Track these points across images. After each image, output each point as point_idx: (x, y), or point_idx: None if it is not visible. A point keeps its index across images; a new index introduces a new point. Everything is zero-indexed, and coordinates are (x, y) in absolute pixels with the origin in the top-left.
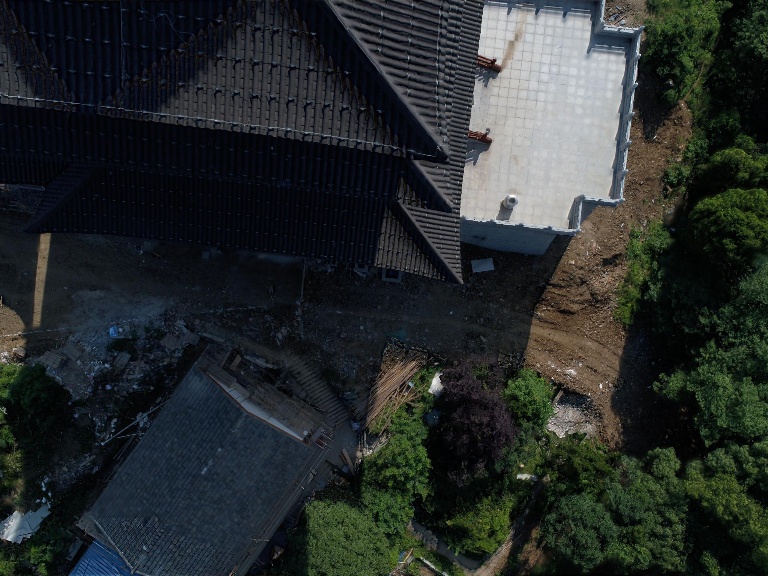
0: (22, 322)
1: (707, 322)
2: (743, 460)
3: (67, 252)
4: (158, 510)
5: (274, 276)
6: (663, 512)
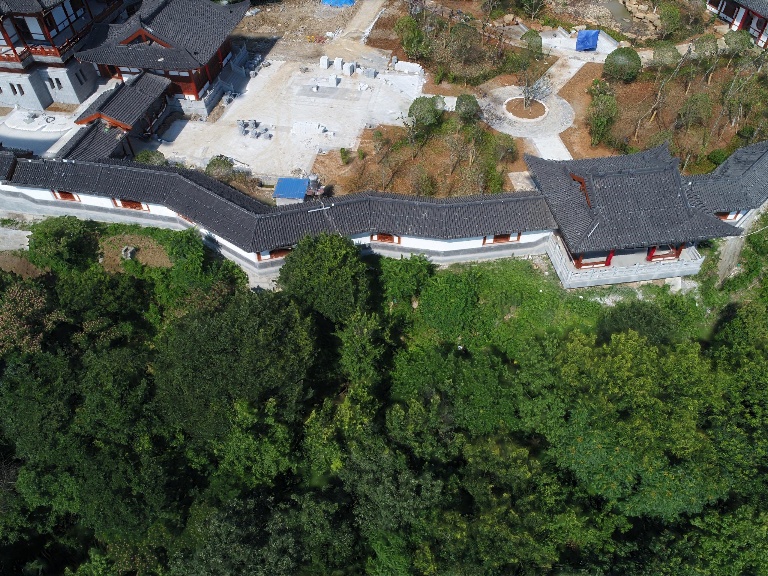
0: None
1: None
2: None
3: None
4: None
5: None
6: None
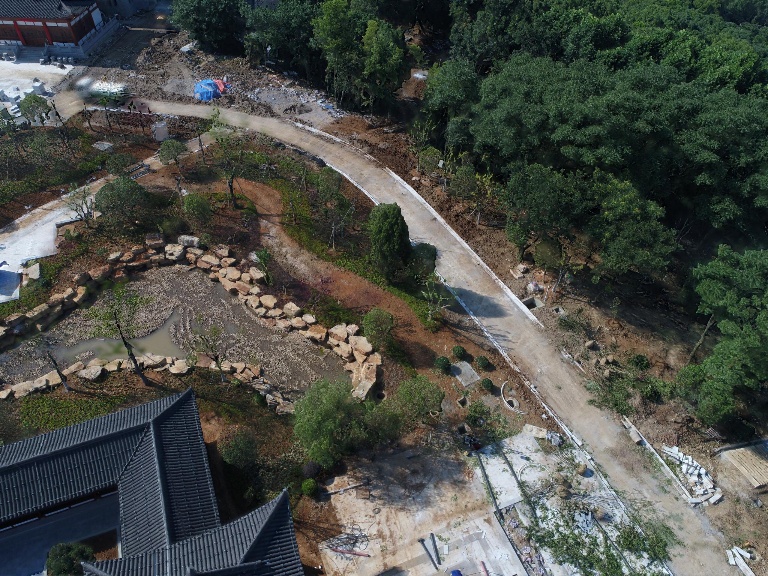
0: None
1: None
2: None
3: None
4: None
5: None
6: None
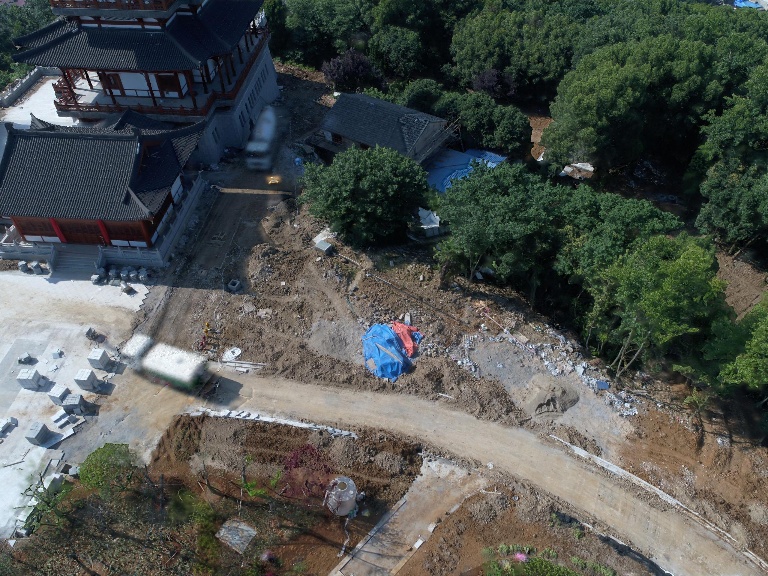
0: (289, 199)
1: (311, 28)
2: (365, 8)
3: (246, 182)
4: (396, 120)
5: (274, 116)
6: (392, 32)
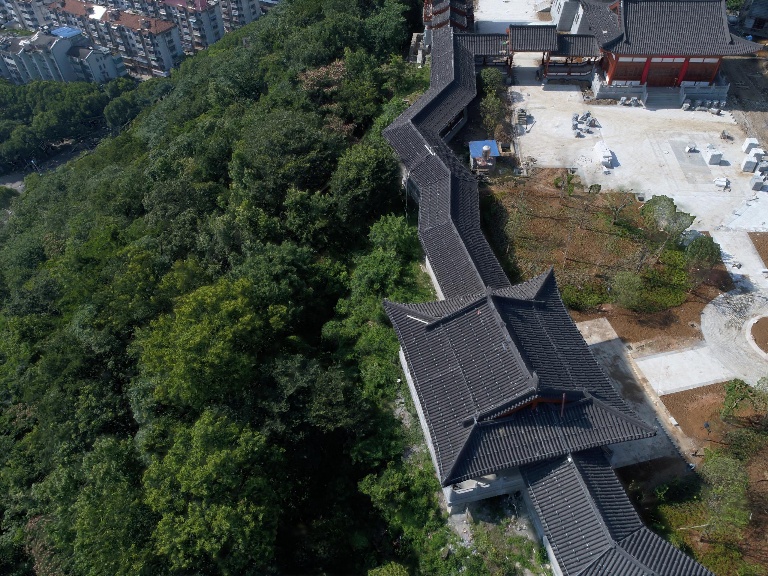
0: (767, 61)
1: None
2: None
3: None
4: None
5: None
6: None
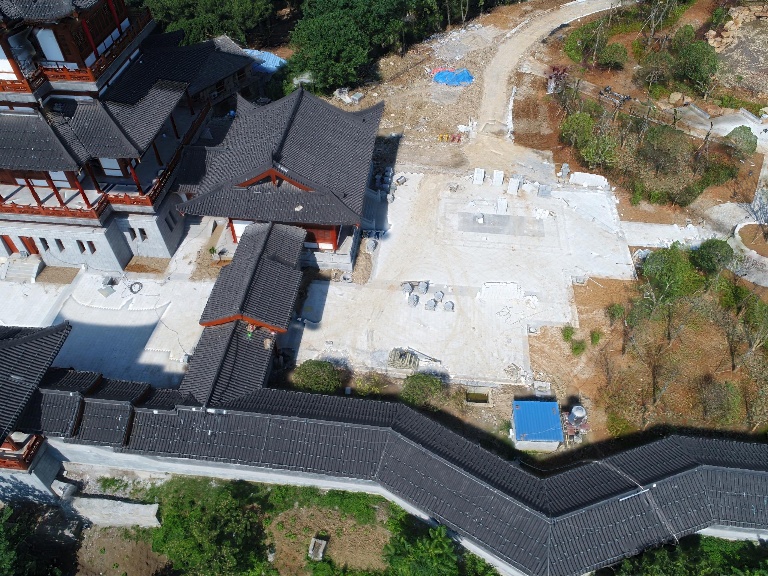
0: None
1: None
2: None
3: None
4: None
5: None
6: None
